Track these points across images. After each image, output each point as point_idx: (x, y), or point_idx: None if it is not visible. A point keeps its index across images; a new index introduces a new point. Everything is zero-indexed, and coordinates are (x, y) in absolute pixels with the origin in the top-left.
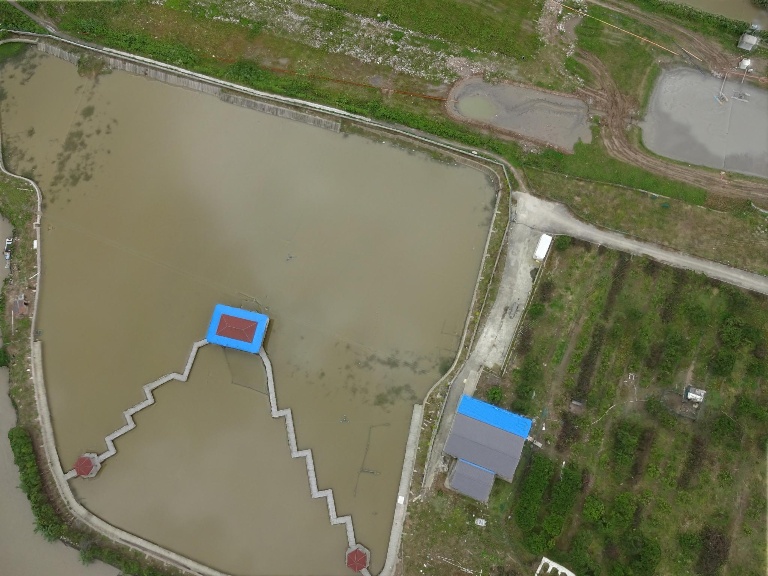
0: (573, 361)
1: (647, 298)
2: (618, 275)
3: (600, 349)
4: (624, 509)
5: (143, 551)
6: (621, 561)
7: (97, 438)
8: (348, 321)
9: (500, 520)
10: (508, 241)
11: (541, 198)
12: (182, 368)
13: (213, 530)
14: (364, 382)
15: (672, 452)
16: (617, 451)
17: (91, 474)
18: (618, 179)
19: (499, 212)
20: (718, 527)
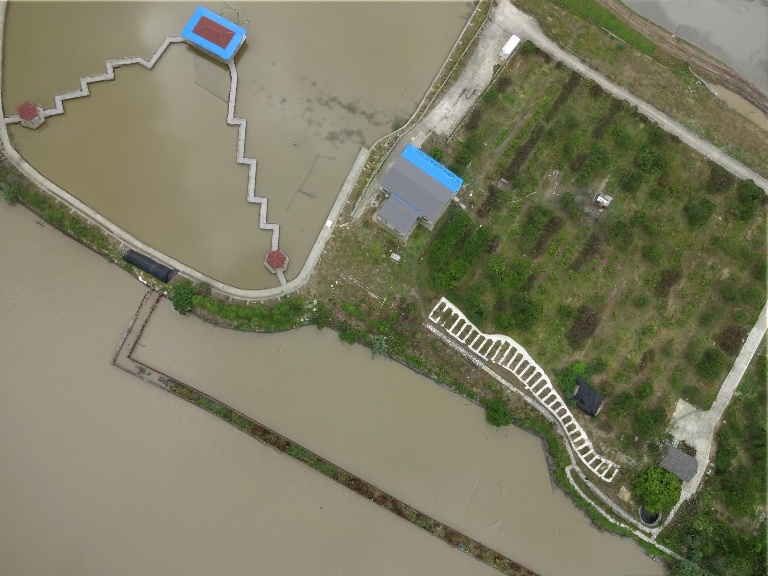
0: (511, 145)
1: (585, 115)
2: (567, 88)
3: (536, 143)
4: (522, 270)
5: (69, 205)
6: (507, 315)
7: (46, 96)
8: (321, 57)
9: (413, 259)
10: (481, 35)
11: (519, 8)
12: (149, 58)
13: (144, 207)
14: (321, 117)
15: (572, 241)
16: (528, 225)
17: (32, 125)
18: (588, 13)
19: (480, 10)
20: (593, 308)
